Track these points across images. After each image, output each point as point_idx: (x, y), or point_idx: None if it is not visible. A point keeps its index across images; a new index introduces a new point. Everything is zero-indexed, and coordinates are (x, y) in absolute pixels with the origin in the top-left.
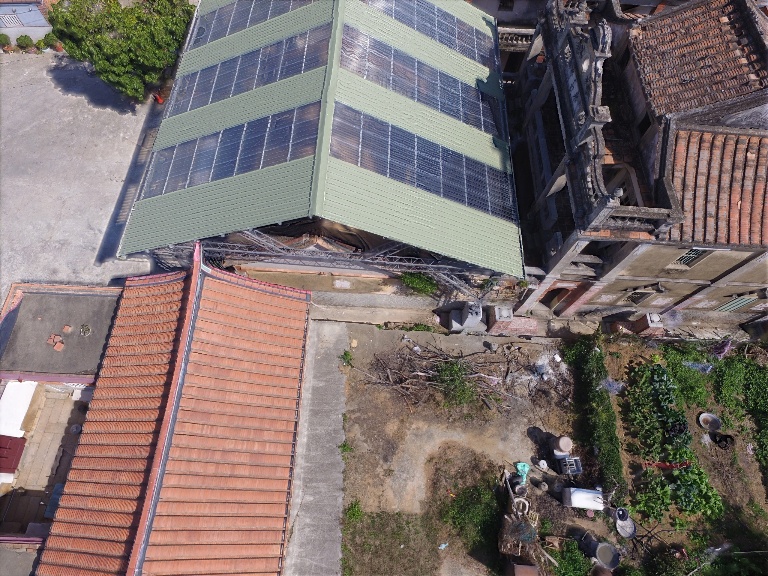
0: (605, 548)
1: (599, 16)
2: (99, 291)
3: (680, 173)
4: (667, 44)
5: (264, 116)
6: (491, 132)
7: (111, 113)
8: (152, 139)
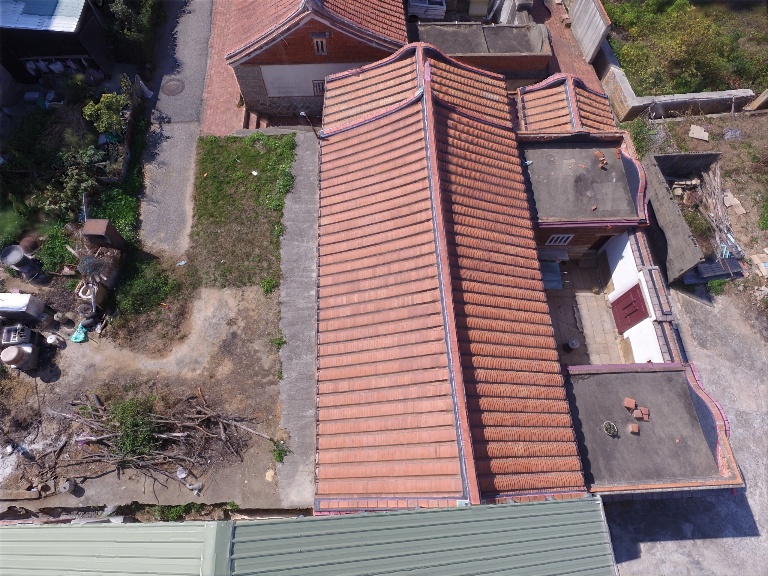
0: (12, 262)
1: None
2: (622, 485)
3: None
4: None
5: None
6: None
7: None
8: None
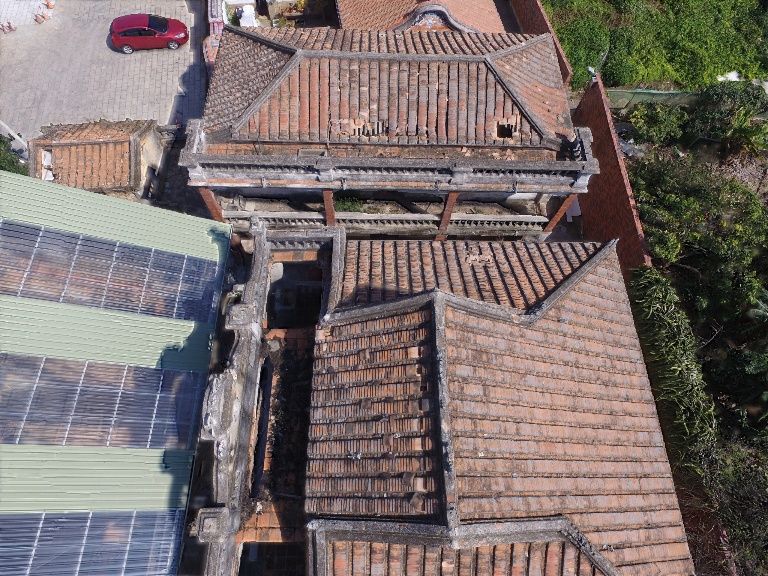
0: None
1: (329, 255)
2: None
3: None
4: (347, 373)
5: None
6: (164, 442)
7: None
8: None
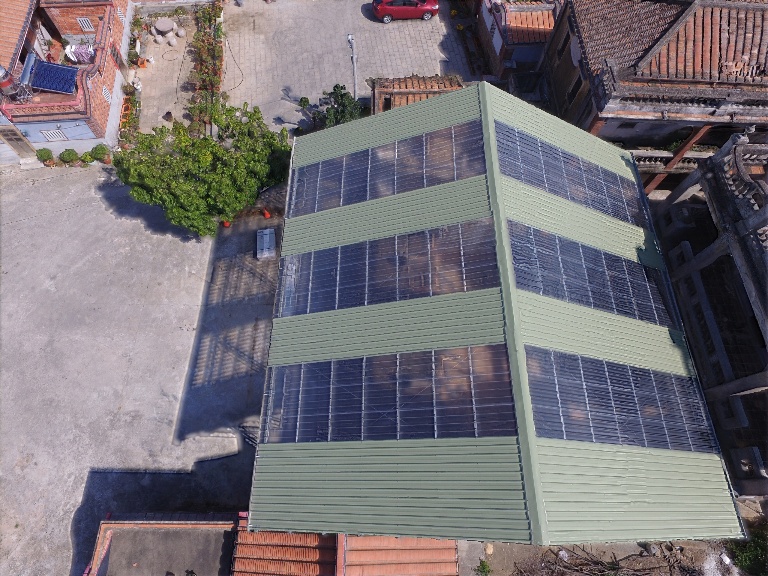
0: None
1: None
2: (205, 529)
3: None
4: None
5: (423, 349)
6: (665, 322)
7: (172, 240)
8: (222, 273)
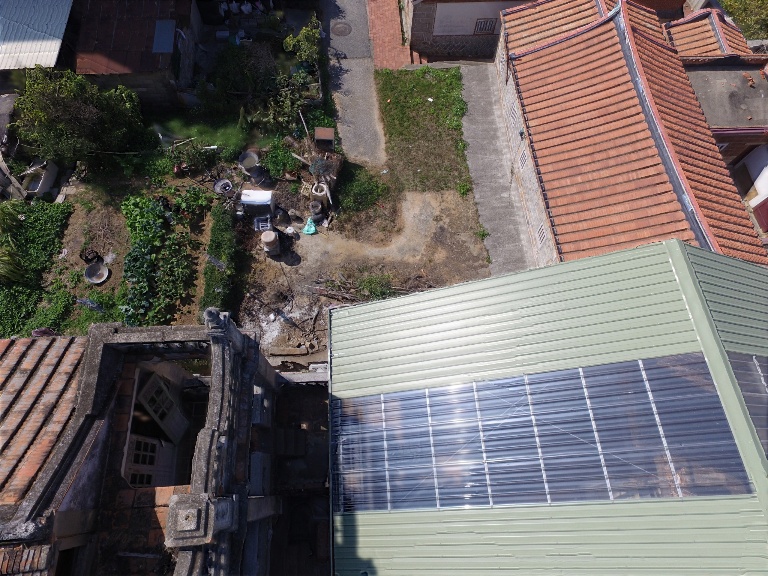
0: (248, 166)
1: None
2: None
3: (49, 430)
4: None
5: None
6: None
7: None
8: None
